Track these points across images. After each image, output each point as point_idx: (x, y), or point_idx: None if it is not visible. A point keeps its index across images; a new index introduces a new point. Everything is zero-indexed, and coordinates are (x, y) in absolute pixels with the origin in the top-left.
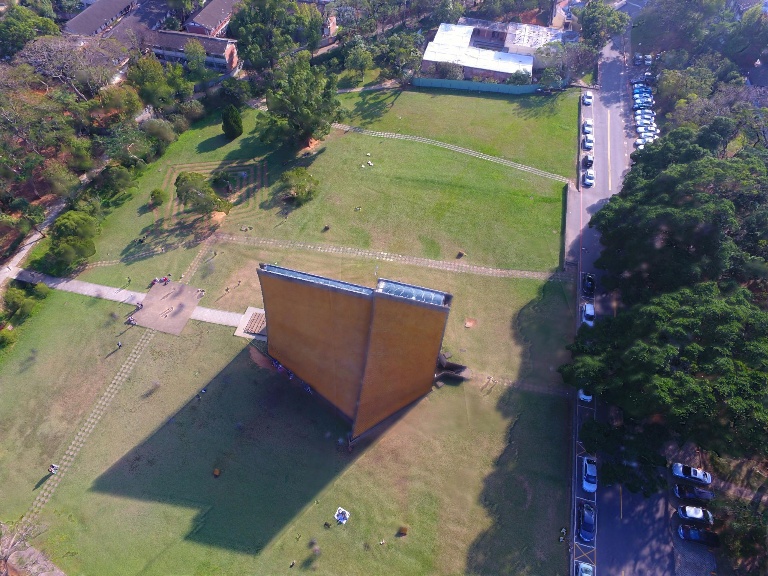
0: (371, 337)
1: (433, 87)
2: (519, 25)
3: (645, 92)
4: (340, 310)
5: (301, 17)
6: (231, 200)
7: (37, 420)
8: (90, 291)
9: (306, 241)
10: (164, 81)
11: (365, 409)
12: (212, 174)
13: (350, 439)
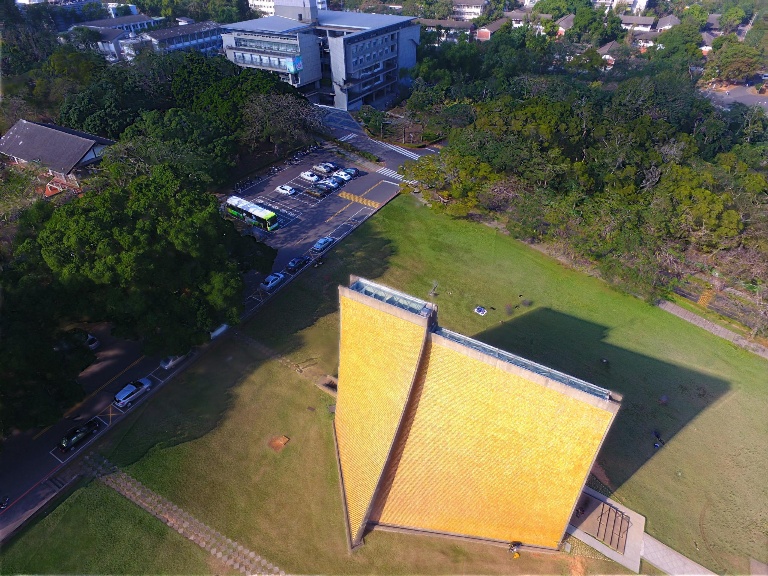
0: None
1: None
2: None
3: None
4: None
5: None
6: None
7: None
8: None
9: None
10: None
11: None
12: None
13: None
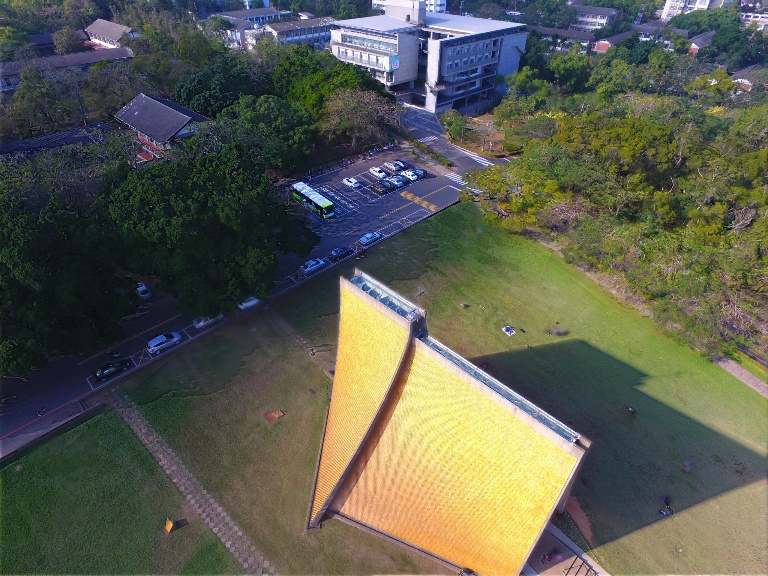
0: None
1: None
2: None
3: None
4: None
5: None
6: None
7: None
8: None
9: None
10: None
11: None
12: None
13: None
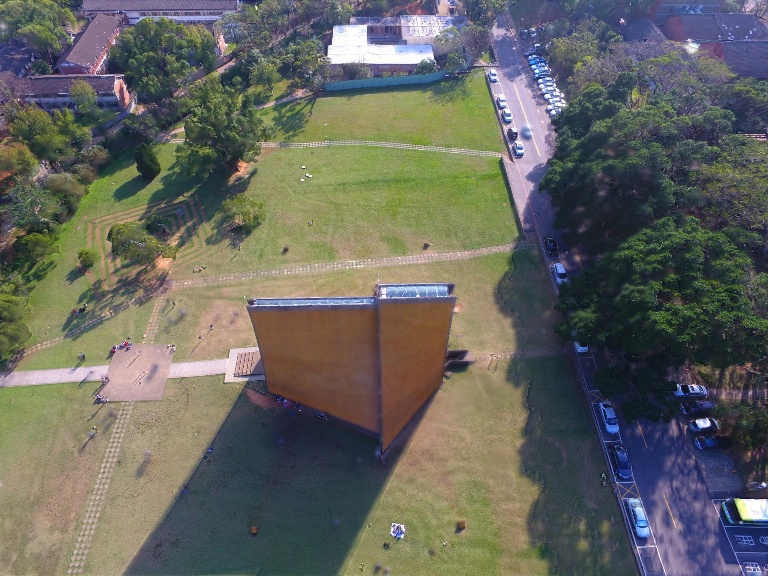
0: (381, 345)
1: (345, 89)
2: (409, 17)
3: (540, 62)
4: (342, 327)
5: (192, 39)
6: (172, 243)
7: (21, 541)
8: (38, 379)
9: (269, 267)
10: (57, 131)
11: (388, 419)
12: (141, 220)
13: (381, 453)
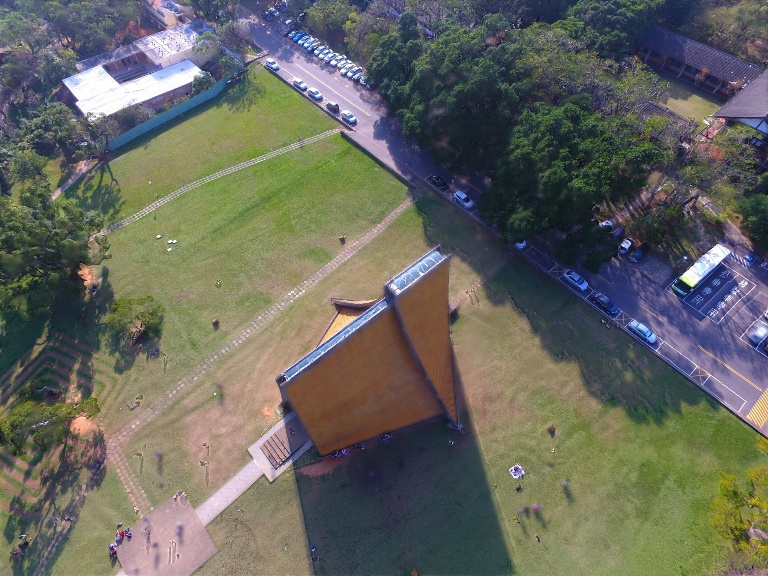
0: (410, 337)
1: (133, 140)
2: (144, 40)
3: (302, 36)
4: (368, 344)
5: None
6: (74, 399)
7: None
8: None
9: (214, 350)
10: None
11: (444, 395)
12: (6, 402)
13: (455, 427)
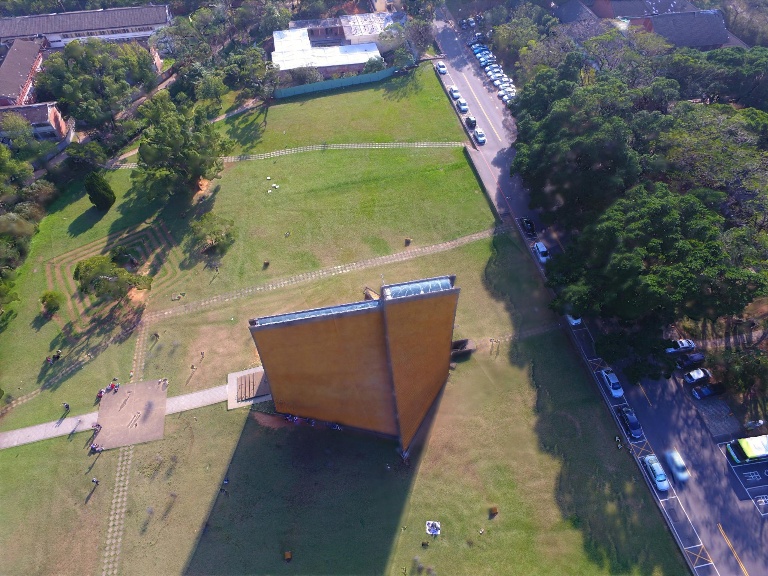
0: (390, 347)
1: (297, 95)
2: (349, 17)
3: (484, 50)
4: (348, 334)
5: (127, 58)
6: (143, 273)
7: None
8: (20, 439)
9: (252, 285)
10: None
11: (405, 419)
12: (104, 254)
13: (402, 454)
